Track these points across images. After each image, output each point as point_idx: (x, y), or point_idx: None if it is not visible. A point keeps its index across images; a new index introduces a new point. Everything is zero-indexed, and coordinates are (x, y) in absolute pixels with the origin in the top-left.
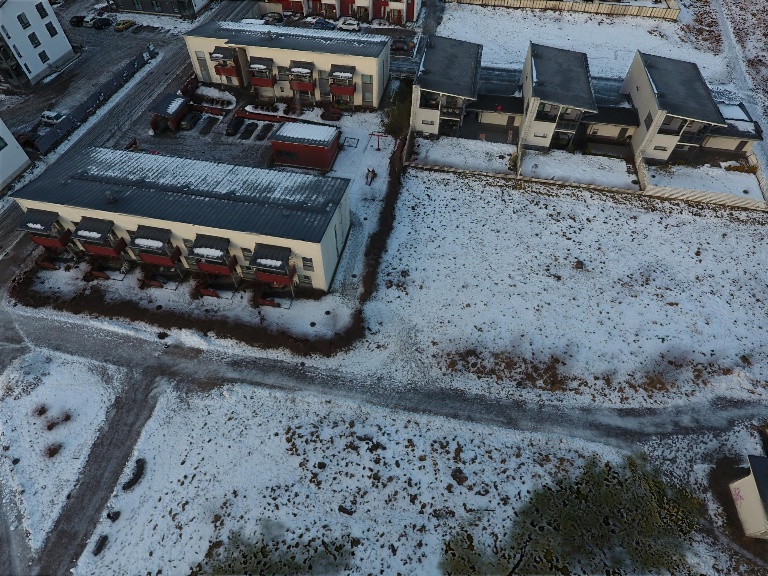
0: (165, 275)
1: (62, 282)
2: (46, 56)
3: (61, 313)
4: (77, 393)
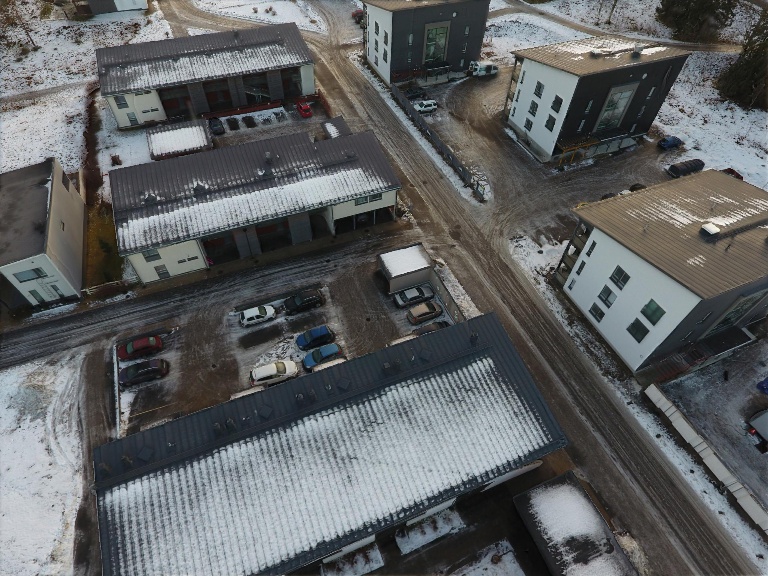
0: None
1: None
2: None
3: None
4: None
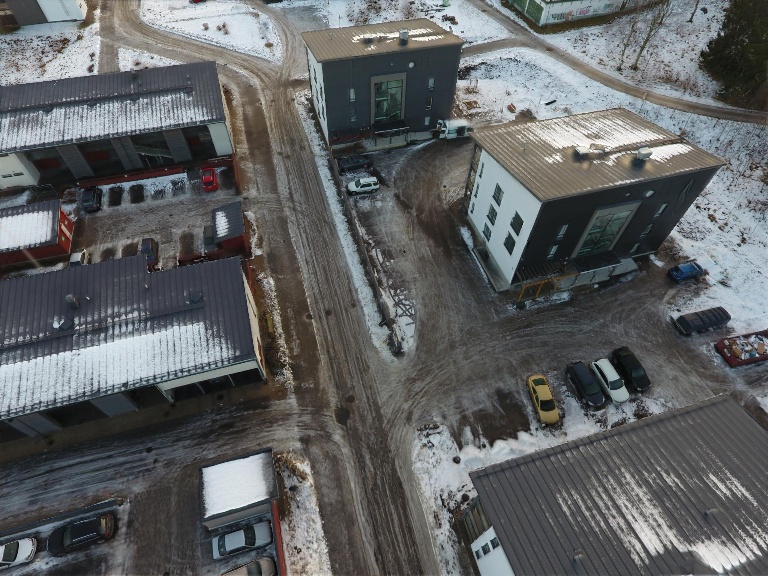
0: None
1: None
2: None
3: None
4: None
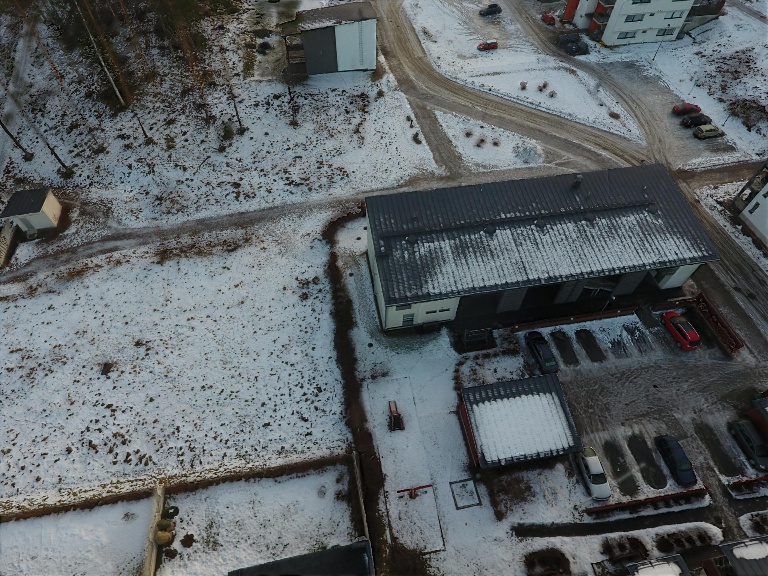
0: None
1: None
2: None
3: None
4: (487, 155)
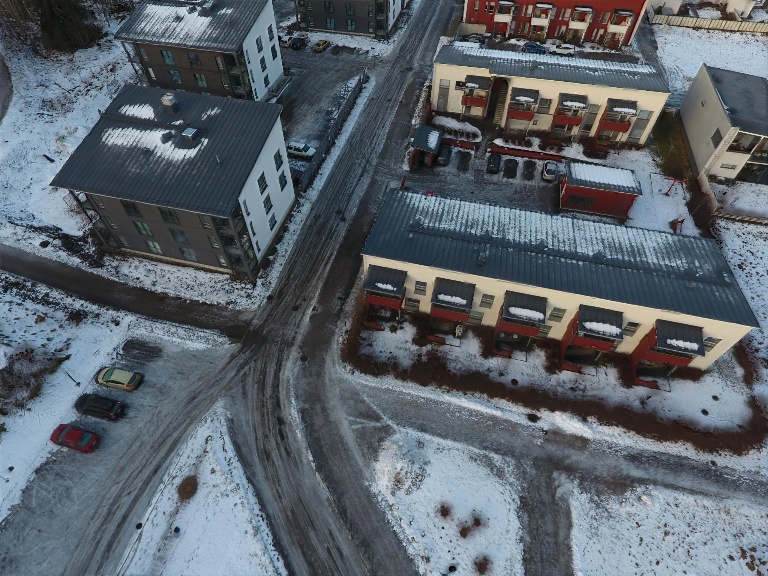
0: (506, 342)
1: (392, 345)
2: (267, 80)
3: (407, 384)
4: (473, 489)
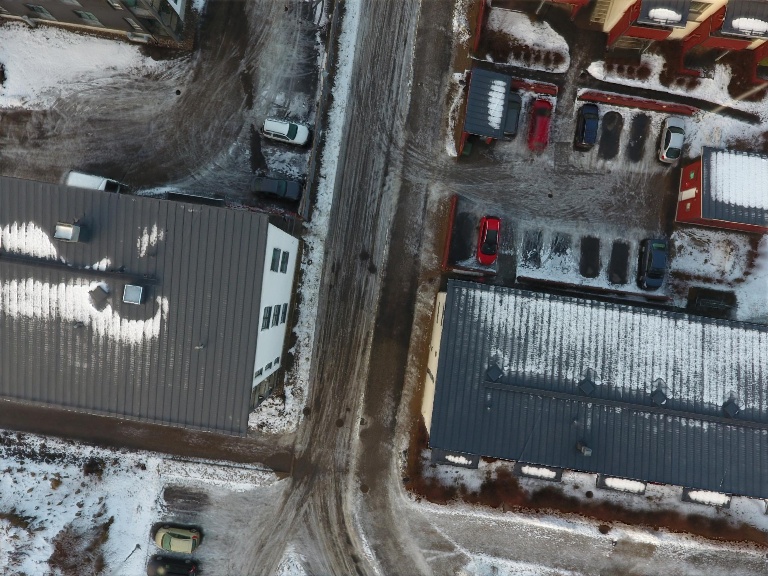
0: None
1: None
2: None
3: (478, 508)
4: None
